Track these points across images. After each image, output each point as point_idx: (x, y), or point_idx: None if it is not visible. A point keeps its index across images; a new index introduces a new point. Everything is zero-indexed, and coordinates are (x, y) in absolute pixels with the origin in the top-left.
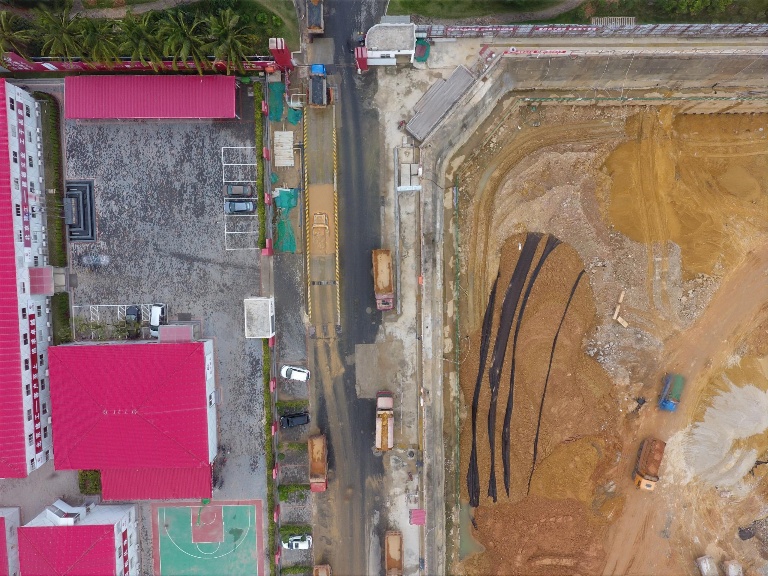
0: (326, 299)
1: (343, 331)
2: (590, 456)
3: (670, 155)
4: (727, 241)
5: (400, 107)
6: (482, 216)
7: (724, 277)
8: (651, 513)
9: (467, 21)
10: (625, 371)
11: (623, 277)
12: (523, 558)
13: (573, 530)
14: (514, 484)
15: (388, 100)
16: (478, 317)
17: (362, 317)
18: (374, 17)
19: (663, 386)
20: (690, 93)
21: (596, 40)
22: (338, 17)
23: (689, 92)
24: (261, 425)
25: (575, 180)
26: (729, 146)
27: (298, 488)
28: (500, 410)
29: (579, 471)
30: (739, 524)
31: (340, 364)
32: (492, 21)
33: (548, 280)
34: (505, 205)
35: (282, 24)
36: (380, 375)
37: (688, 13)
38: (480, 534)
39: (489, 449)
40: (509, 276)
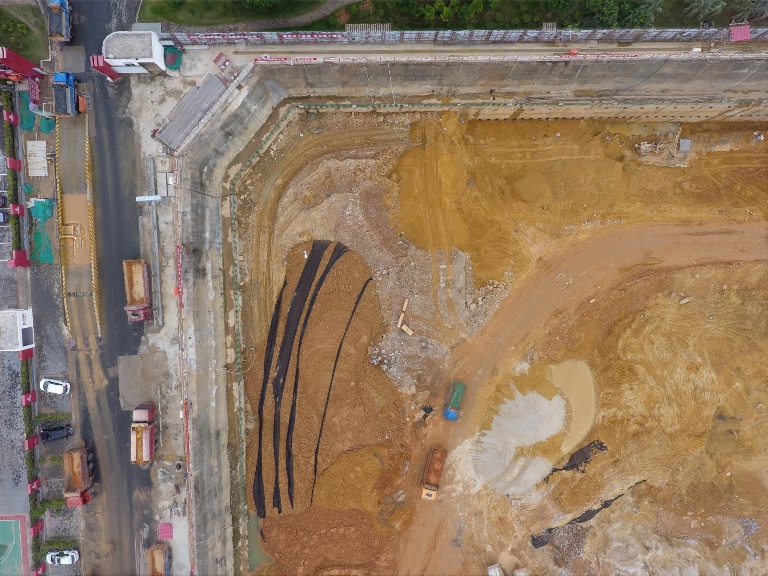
0: (84, 310)
1: (104, 343)
2: (371, 466)
3: (464, 161)
4: (517, 247)
5: (155, 115)
6: (266, 224)
7: (513, 284)
8: (442, 522)
9: (219, 28)
10: (411, 379)
11: (407, 285)
12: (305, 569)
13: (359, 540)
14: (298, 495)
15: (142, 108)
16: (264, 326)
17: (123, 328)
18: (125, 24)
19: (450, 394)
20: (468, 99)
21: (351, 47)
22: (88, 24)
23: (467, 98)
24: (23, 439)
25: (354, 187)
26: (526, 152)
27: (61, 502)
28: (284, 420)
29: (360, 481)
30: (531, 532)
31: (103, 376)
32: (245, 28)
33: (333, 288)
34: (287, 213)
35: (29, 32)
36: (144, 387)
37: (440, 19)
38: (268, 545)
39: (273, 460)
40: (294, 285)
